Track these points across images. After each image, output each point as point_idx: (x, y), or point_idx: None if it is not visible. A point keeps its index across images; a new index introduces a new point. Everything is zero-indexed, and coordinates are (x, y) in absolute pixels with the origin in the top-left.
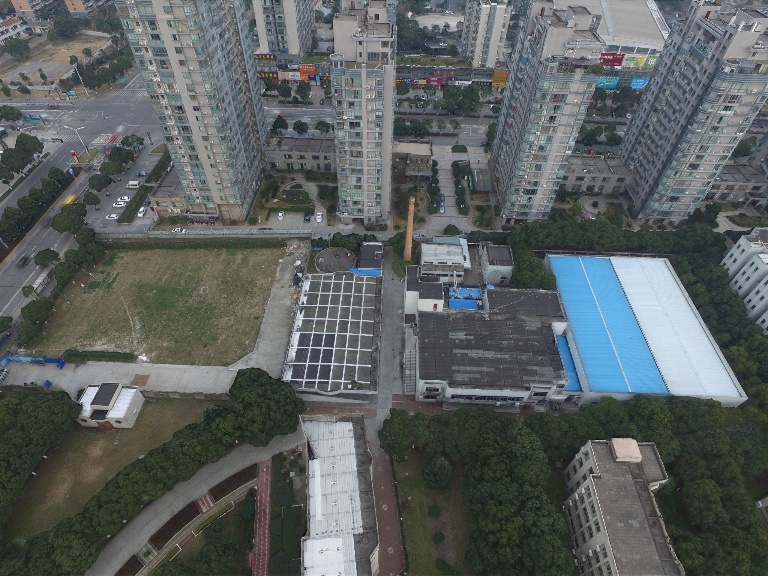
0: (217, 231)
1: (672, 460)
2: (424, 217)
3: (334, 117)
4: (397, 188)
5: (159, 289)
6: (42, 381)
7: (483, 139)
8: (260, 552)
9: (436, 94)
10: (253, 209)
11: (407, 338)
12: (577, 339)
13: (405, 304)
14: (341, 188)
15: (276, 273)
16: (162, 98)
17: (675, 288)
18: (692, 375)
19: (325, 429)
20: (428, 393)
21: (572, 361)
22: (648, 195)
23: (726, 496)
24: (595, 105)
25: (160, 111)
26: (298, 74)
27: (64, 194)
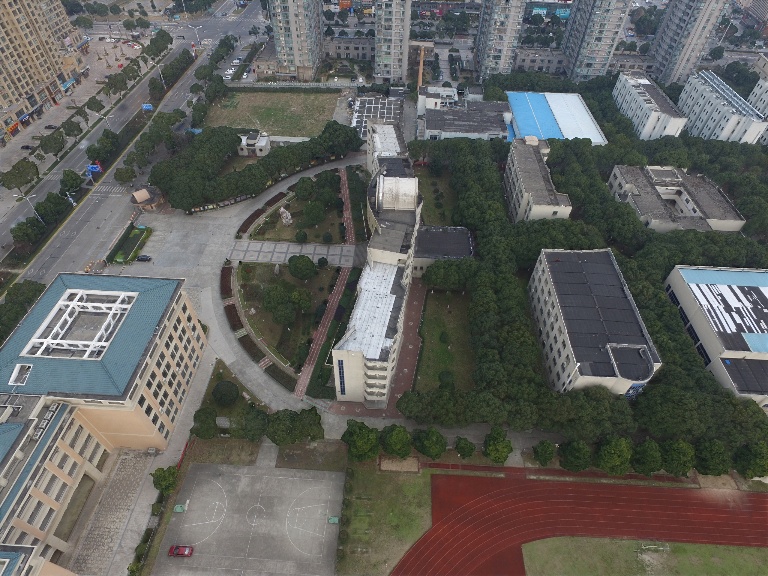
0: (297, 83)
1: (560, 161)
2: (429, 81)
3: (376, 1)
4: (411, 67)
5: (266, 108)
6: None
7: (471, 46)
8: (345, 194)
9: (438, 22)
10: (317, 76)
11: (419, 123)
12: (518, 123)
13: (418, 107)
14: (377, 54)
15: (337, 103)
16: None
17: (581, 106)
18: (580, 135)
19: (379, 126)
20: (431, 141)
21: (514, 133)
22: (574, 65)
23: (584, 170)
24: (552, 28)
25: None
26: (338, 7)
27: (191, 68)
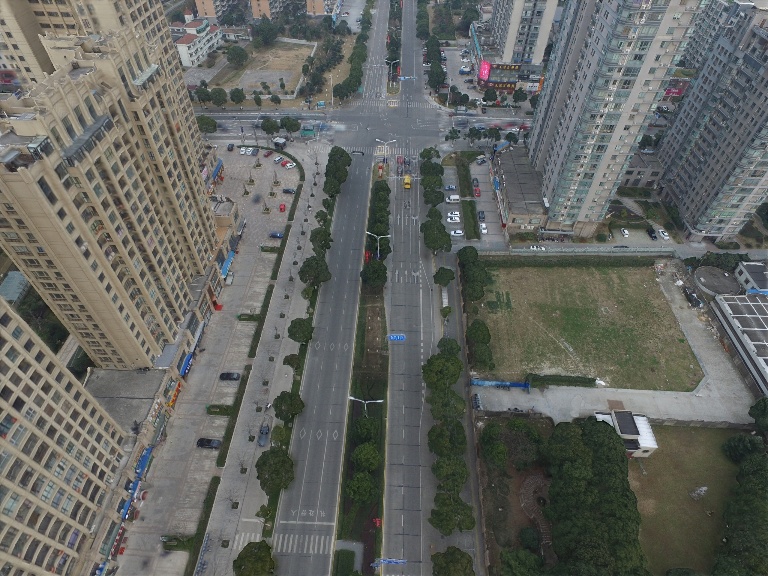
0: (579, 249)
1: None
2: (766, 235)
3: (759, 137)
4: None
5: (561, 309)
6: (520, 406)
7: None
8: None
9: None
10: None
11: None
12: None
13: None
14: (716, 207)
15: (664, 293)
16: (599, 117)
17: None
18: None
19: None
20: None
21: None
22: None
23: None
24: None
25: (589, 130)
26: (537, 85)
27: (388, 208)
